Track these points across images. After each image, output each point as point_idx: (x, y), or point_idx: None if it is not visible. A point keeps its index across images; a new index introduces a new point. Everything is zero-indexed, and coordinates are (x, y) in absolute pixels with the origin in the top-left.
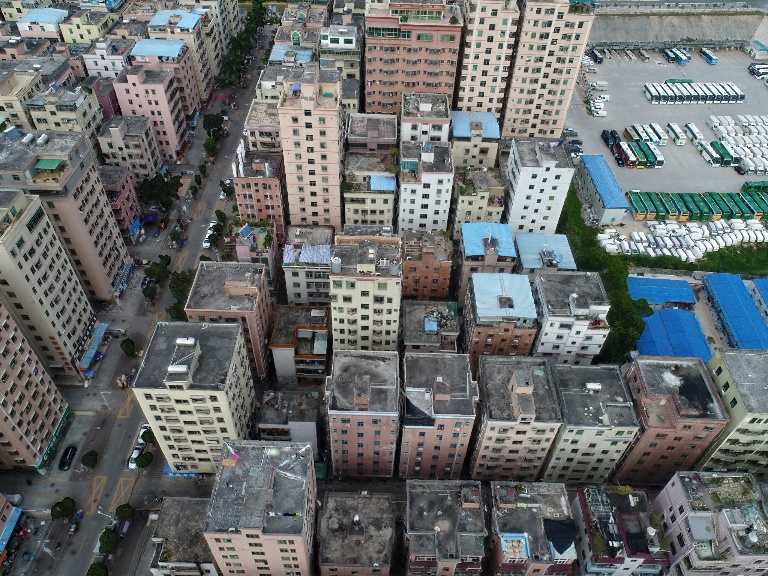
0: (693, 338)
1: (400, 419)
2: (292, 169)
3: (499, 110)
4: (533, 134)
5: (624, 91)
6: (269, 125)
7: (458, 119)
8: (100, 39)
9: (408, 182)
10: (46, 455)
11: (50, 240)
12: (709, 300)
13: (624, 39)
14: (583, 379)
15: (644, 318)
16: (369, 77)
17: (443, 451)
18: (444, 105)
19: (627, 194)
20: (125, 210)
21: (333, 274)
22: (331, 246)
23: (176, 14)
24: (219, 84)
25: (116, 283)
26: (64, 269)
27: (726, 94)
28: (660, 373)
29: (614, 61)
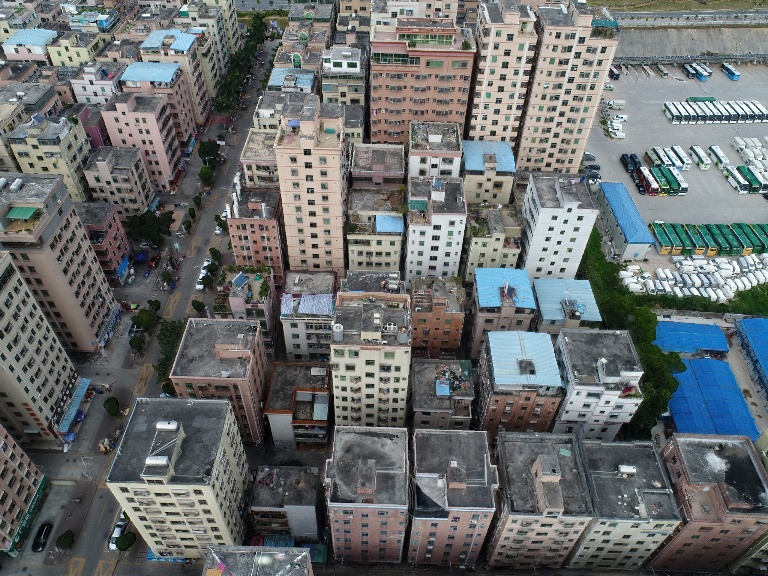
0: (728, 393)
1: (410, 511)
2: (291, 210)
3: (514, 139)
4: (550, 164)
5: (643, 110)
6: (267, 158)
7: (470, 150)
8: (89, 63)
9: (417, 224)
10: (17, 536)
11: (22, 299)
12: (743, 348)
13: (641, 53)
14: (615, 459)
15: None
16: (374, 105)
17: (457, 540)
18: (455, 136)
19: (650, 226)
20: (112, 250)
21: (334, 342)
22: (333, 295)
23: (170, 35)
24: (216, 107)
25: (101, 333)
26: (39, 328)
27: (751, 113)
28: (703, 454)
29: (631, 77)
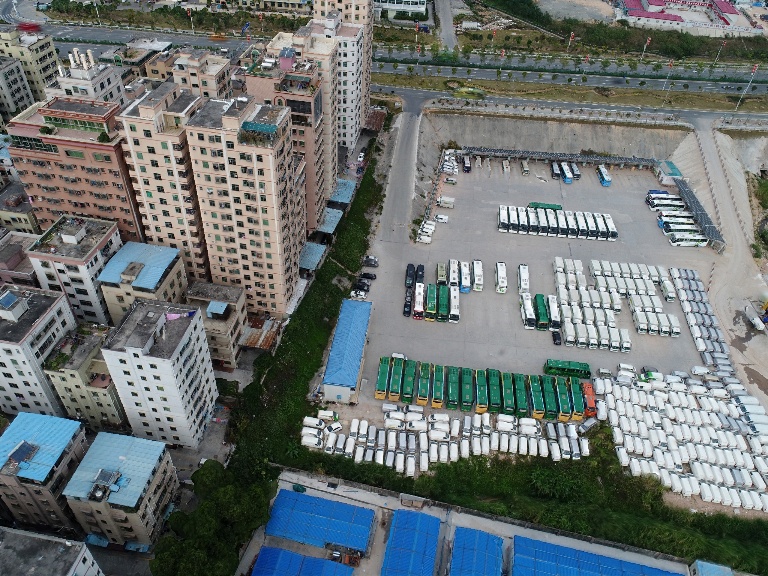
0: None
1: None
2: None
3: (199, 244)
4: (249, 276)
5: (475, 211)
6: None
7: (123, 255)
8: None
9: None
10: None
11: None
12: None
13: (512, 145)
14: None
15: (271, 570)
16: (28, 191)
17: None
18: None
19: (380, 360)
20: None
21: None
22: None
23: None
24: None
25: None
26: None
27: (593, 229)
28: None
29: None
